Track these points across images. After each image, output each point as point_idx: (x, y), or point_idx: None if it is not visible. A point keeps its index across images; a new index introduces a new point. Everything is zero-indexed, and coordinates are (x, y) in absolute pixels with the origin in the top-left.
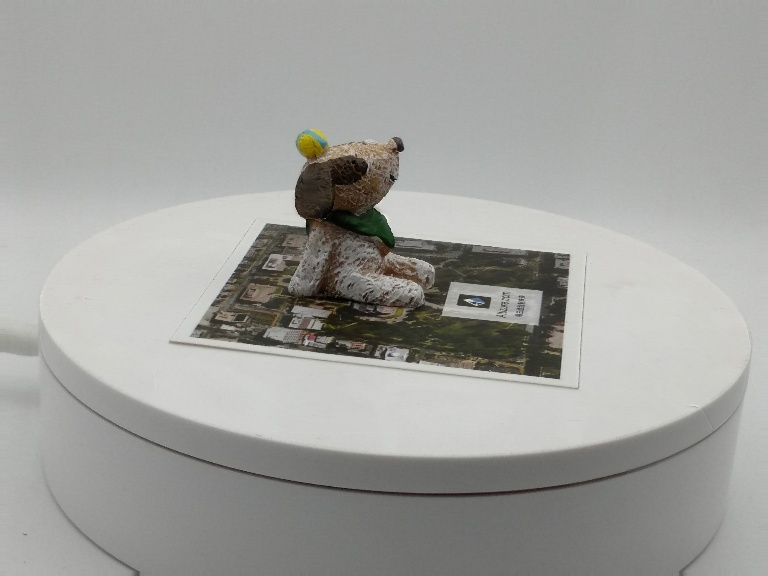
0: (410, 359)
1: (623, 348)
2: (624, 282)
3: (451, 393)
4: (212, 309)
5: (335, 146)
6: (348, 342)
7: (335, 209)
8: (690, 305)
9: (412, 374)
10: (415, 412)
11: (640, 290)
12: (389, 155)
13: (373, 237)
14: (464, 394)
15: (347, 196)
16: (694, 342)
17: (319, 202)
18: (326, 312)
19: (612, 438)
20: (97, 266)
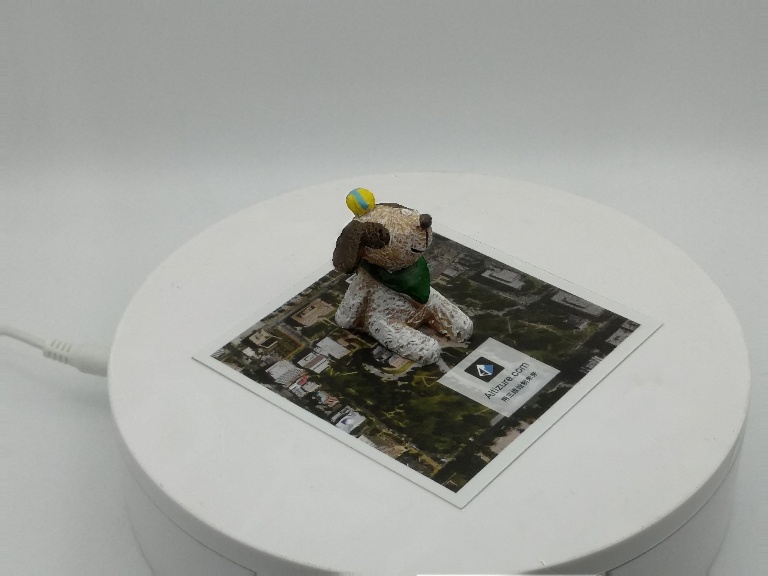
0: (355, 431)
1: (557, 468)
2: (655, 377)
3: (350, 482)
4: (257, 325)
5: (384, 205)
6: (326, 395)
7: (372, 263)
8: (687, 426)
9: (343, 449)
10: (300, 496)
11: (660, 392)
12: (411, 232)
13: (402, 293)
14: (360, 486)
15: (375, 257)
16: (634, 479)
17: (345, 260)
18: (344, 352)
19: None
20: (221, 247)
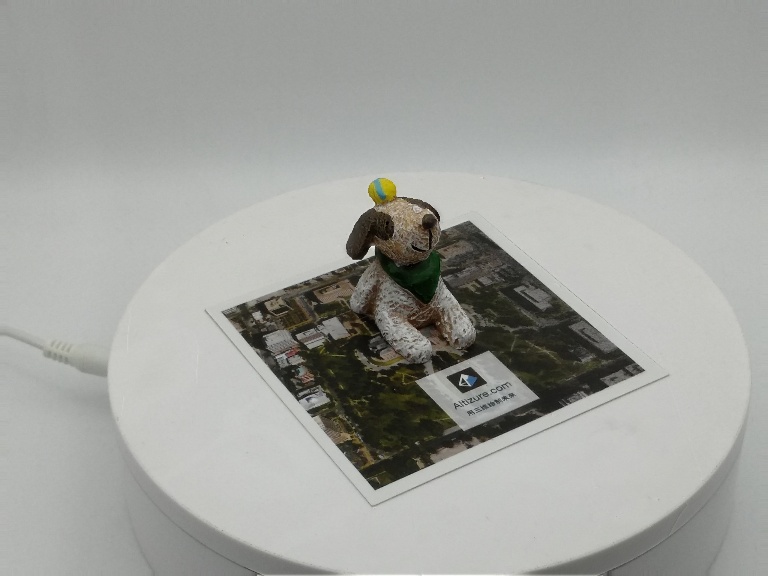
0: (314, 410)
1: (485, 490)
2: (631, 425)
3: (284, 456)
4: (278, 293)
5: (404, 199)
6: (305, 371)
7: (383, 253)
8: (638, 480)
9: (295, 424)
10: (233, 458)
11: (628, 441)
12: (413, 229)
13: (405, 289)
14: (291, 462)
15: (383, 248)
16: (555, 519)
17: (354, 245)
18: (344, 334)
19: (307, 563)
20: (286, 213)
